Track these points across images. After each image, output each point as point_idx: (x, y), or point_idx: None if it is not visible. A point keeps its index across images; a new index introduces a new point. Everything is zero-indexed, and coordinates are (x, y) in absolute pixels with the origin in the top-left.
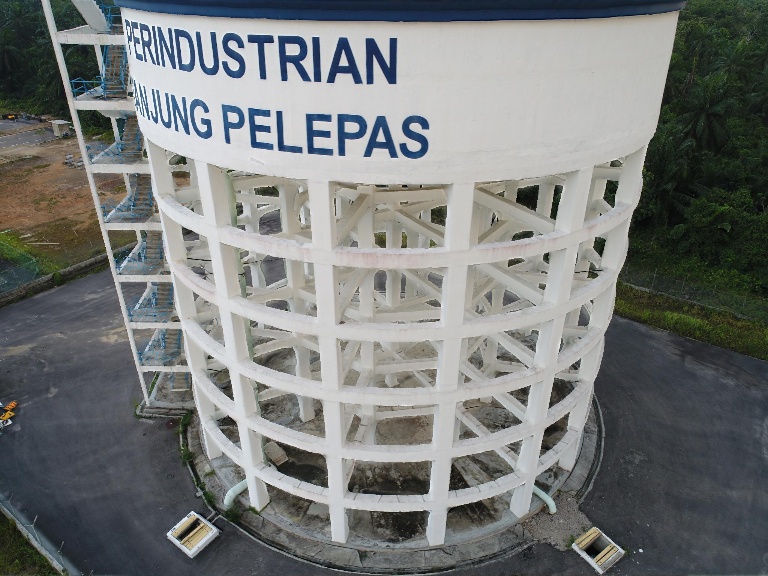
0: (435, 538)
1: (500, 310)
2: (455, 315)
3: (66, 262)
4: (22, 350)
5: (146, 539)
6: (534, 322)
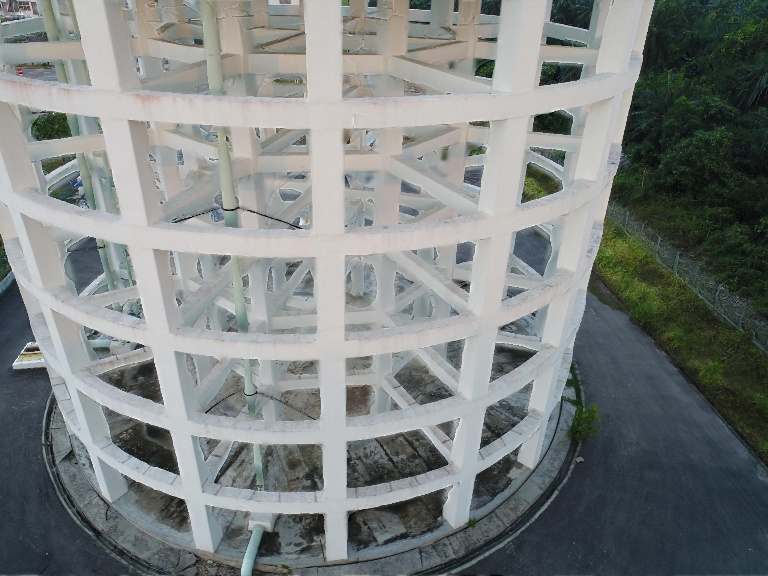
0: (102, 488)
1: (381, 296)
2: (2, 172)
3: None
4: None
5: (23, 340)
6: (94, 233)
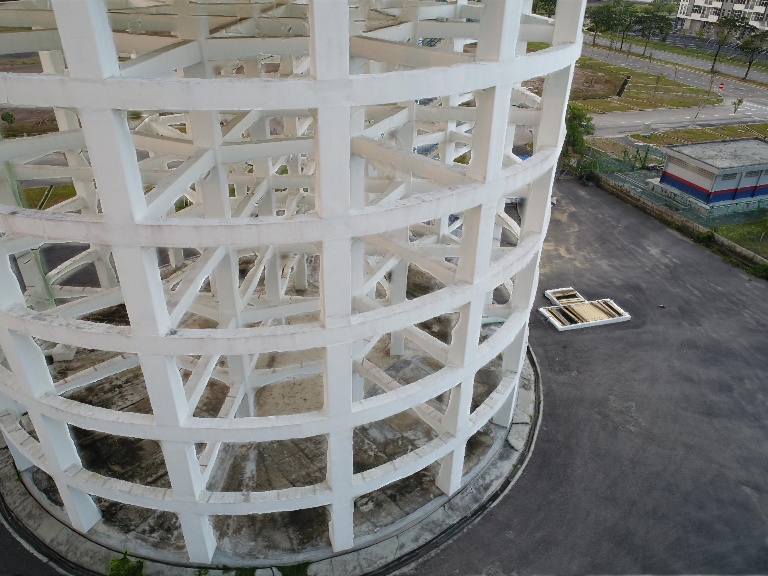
0: None
1: None
2: None
3: (757, 246)
4: (558, 217)
5: None
6: None
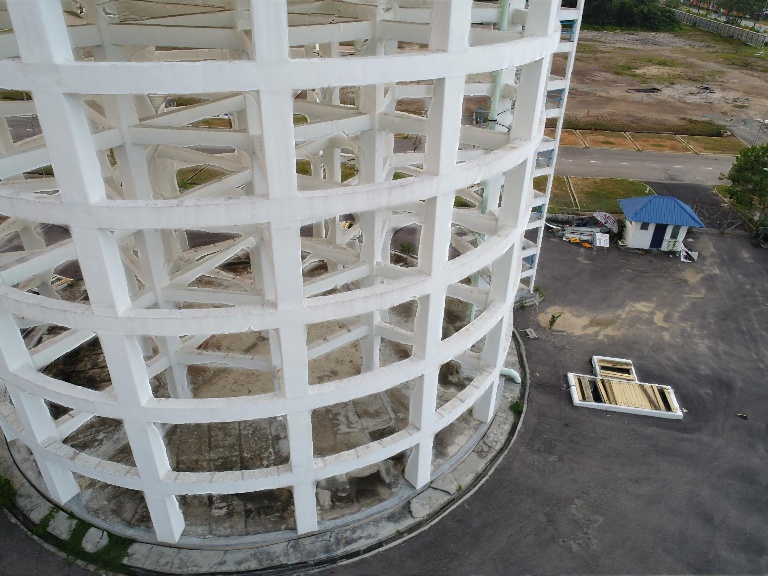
0: None
1: None
2: None
3: None
4: (688, 276)
5: None
6: None
